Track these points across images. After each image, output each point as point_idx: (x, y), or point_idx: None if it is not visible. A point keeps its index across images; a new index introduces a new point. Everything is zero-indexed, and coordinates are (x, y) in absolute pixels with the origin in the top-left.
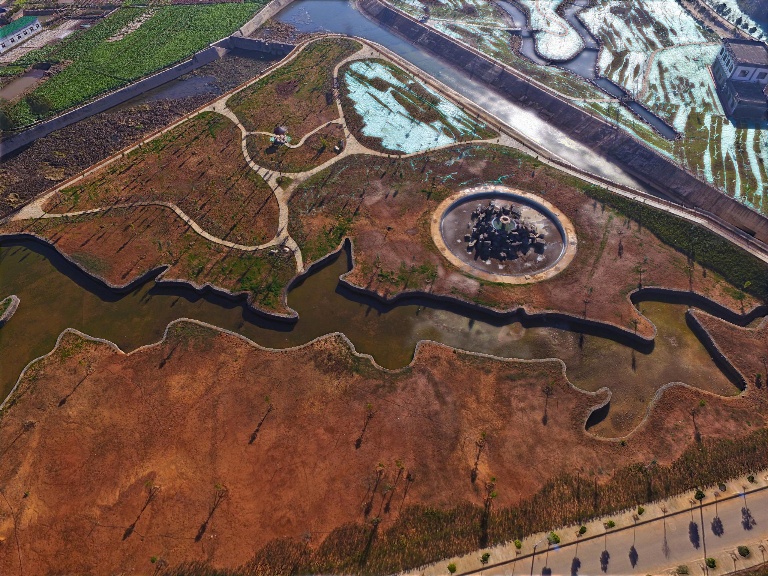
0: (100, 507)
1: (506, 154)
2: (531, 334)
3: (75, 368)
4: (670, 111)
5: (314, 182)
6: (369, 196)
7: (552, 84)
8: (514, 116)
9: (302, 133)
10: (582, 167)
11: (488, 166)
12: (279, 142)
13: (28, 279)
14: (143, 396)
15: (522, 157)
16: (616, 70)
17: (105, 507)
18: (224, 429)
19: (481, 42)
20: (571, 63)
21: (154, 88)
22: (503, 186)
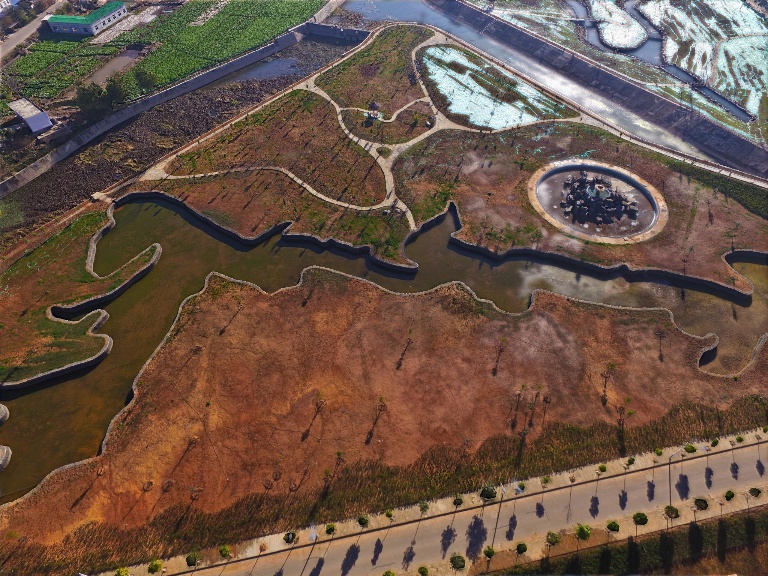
0: (276, 415)
1: (589, 131)
2: (635, 288)
3: (227, 304)
4: (742, 95)
5: (412, 152)
6: (466, 166)
7: (623, 70)
8: (587, 99)
9: (393, 110)
10: None
11: (573, 142)
12: (373, 117)
13: (165, 231)
14: (293, 328)
15: (604, 134)
16: (683, 58)
17: (280, 415)
18: (372, 357)
19: (548, 31)
20: (637, 51)
21: (241, 69)
22: (590, 160)
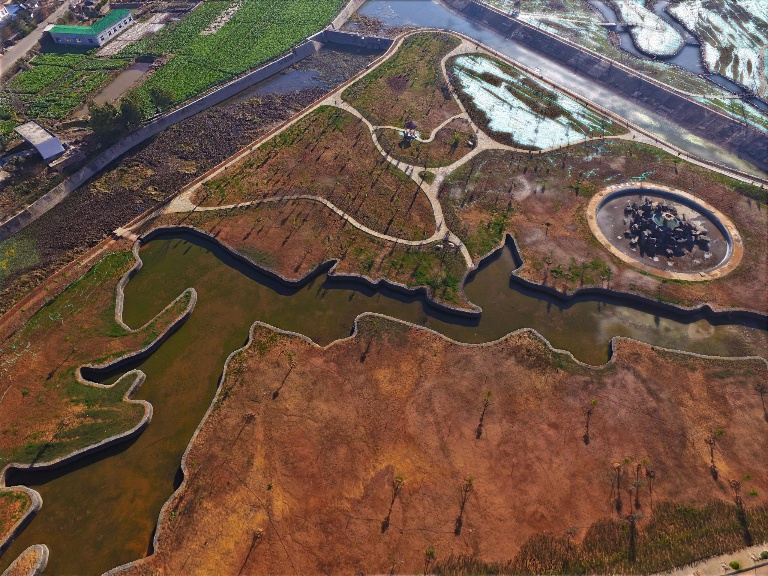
0: (349, 500)
1: (642, 150)
2: (721, 332)
3: (277, 361)
4: None
5: (458, 177)
6: (517, 191)
7: (665, 80)
8: (631, 112)
9: (430, 128)
10: None
11: (628, 162)
12: (410, 137)
13: (198, 272)
14: (355, 390)
15: (659, 153)
16: (727, 66)
17: (354, 500)
18: (447, 423)
19: (580, 37)
20: (675, 59)
21: (259, 82)
22: (648, 182)
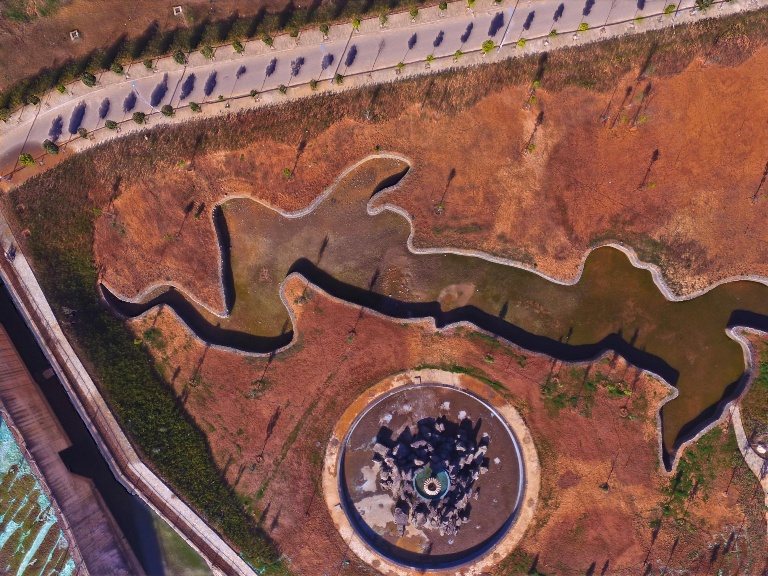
0: None
1: None
2: (433, 293)
3: None
4: None
5: None
6: (636, 568)
7: None
8: None
9: None
10: None
11: None
12: None
13: None
14: None
15: None
16: None
17: None
18: None
19: None
20: None
21: None
22: None
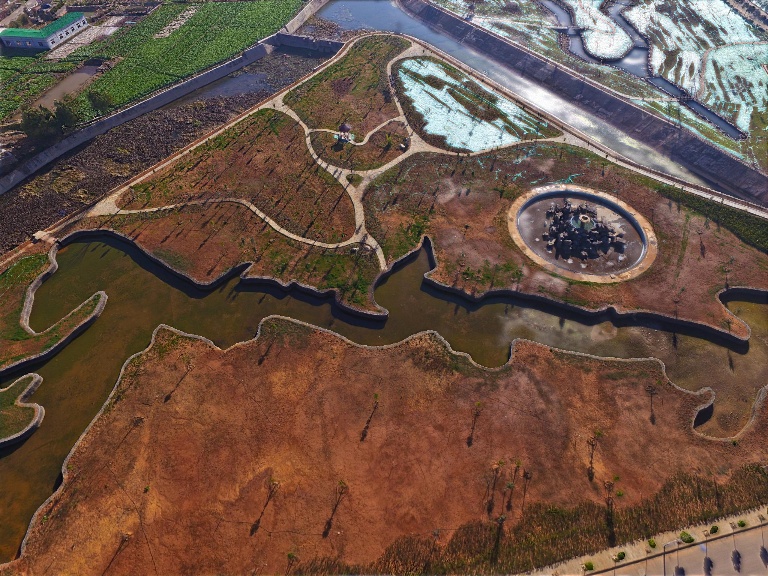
0: (222, 502)
1: (573, 153)
2: (623, 333)
3: (175, 364)
4: (732, 110)
5: (385, 180)
6: (442, 194)
7: (608, 83)
8: (571, 115)
9: (365, 131)
10: (647, 166)
11: (556, 165)
12: (343, 140)
13: (112, 275)
14: (247, 392)
15: (589, 156)
16: (670, 69)
17: (227, 502)
18: (333, 426)
19: (530, 40)
20: (622, 62)
21: (206, 85)
22: (574, 185)
